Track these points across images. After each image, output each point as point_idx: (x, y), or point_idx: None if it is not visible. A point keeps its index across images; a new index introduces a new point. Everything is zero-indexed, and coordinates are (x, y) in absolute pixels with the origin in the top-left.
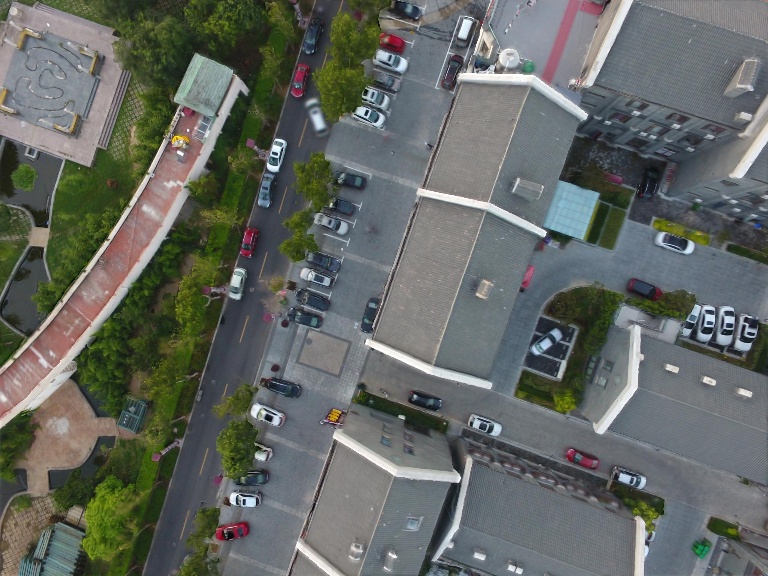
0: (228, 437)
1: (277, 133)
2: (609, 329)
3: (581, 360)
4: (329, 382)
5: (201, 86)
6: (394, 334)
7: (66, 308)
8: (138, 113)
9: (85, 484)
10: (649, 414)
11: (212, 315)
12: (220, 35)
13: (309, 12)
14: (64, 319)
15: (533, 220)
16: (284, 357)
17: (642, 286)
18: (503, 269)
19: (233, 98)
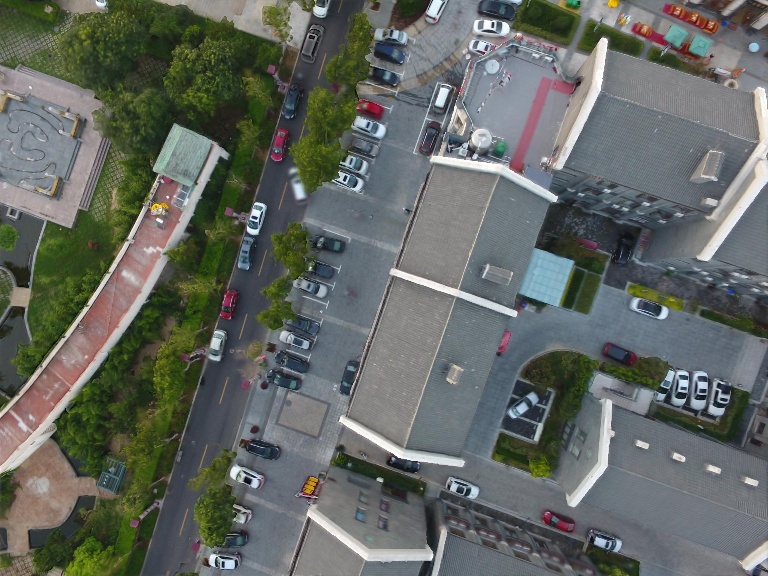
0: (205, 506)
1: (257, 196)
2: (583, 396)
3: (557, 423)
4: (308, 443)
5: (179, 158)
6: (367, 413)
7: (46, 372)
8: (119, 175)
9: (64, 547)
10: (620, 489)
11: (192, 377)
12: (199, 106)
13: (289, 77)
14: (44, 383)
15: (504, 301)
16: (264, 418)
17: (617, 351)
18: (474, 350)
19: (212, 165)
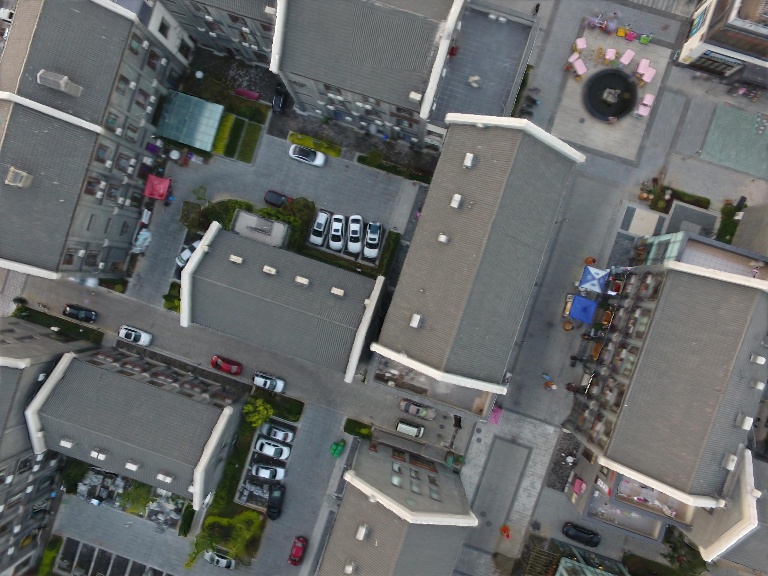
0: None
1: None
2: None
3: None
4: None
5: None
6: None
7: None
8: None
9: None
10: (218, 304)
11: None
12: None
13: None
14: None
15: (86, 116)
16: None
17: (273, 196)
18: (53, 162)
19: None
